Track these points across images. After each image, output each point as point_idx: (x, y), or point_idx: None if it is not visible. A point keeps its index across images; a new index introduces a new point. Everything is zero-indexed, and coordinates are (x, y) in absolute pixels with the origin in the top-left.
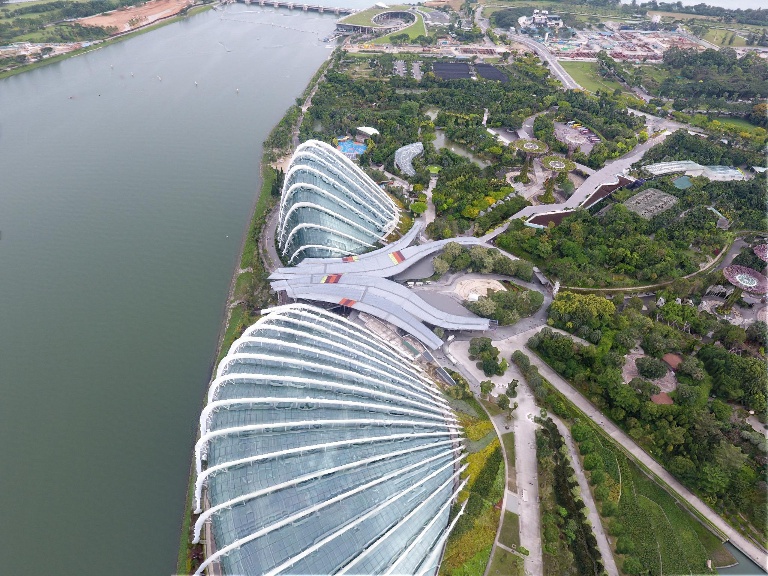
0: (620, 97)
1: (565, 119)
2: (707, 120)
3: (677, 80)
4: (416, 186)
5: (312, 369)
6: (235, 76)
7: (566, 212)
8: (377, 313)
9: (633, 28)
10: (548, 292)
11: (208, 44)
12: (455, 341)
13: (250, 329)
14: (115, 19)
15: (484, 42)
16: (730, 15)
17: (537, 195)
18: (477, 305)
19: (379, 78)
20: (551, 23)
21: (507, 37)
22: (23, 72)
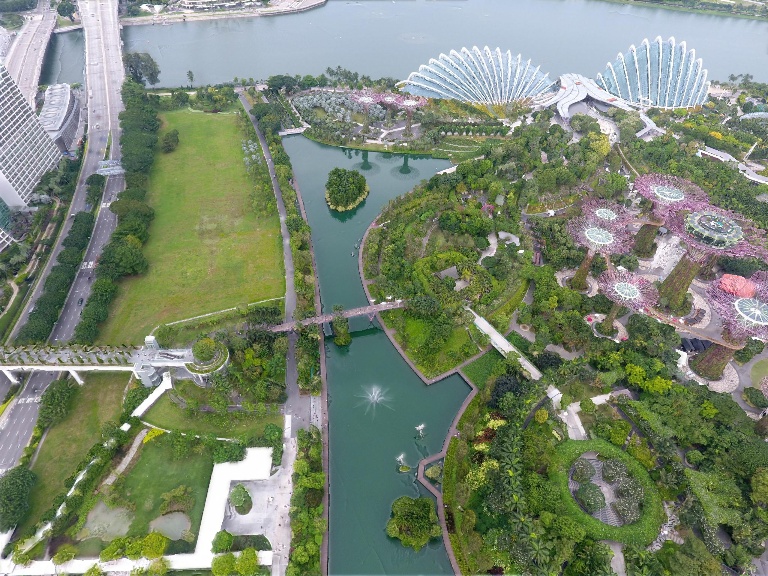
0: None
1: None
2: None
3: None
4: None
5: None
6: None
7: (739, 172)
8: None
9: None
10: None
11: None
12: None
13: None
14: None
15: None
16: None
17: None
18: None
19: None
20: None
21: None
22: (763, 21)
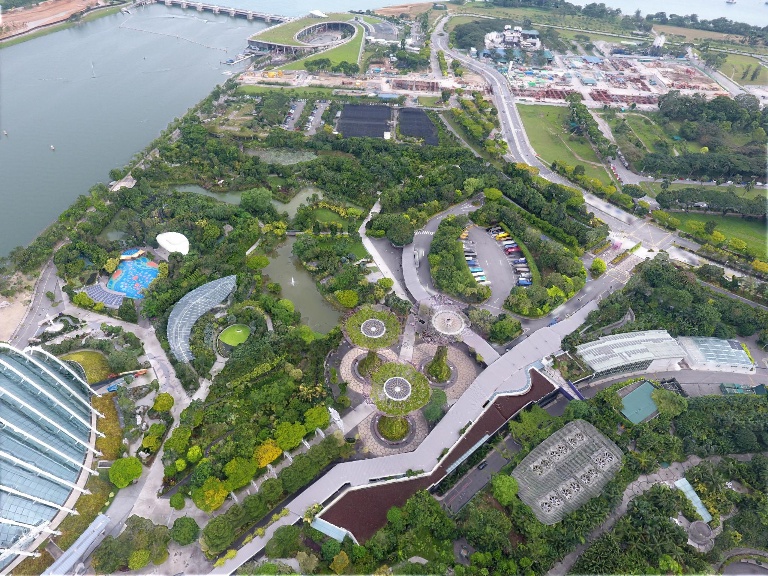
0: (582, 178)
1: (488, 222)
2: (704, 231)
3: (671, 146)
4: (157, 402)
5: None
6: (72, 120)
7: (408, 480)
8: None
9: (629, 52)
10: None
11: (75, 65)
12: None
13: None
14: None
15: (429, 70)
16: (756, 36)
17: None
18: None
19: (255, 132)
20: (526, 42)
21: (462, 63)
22: None
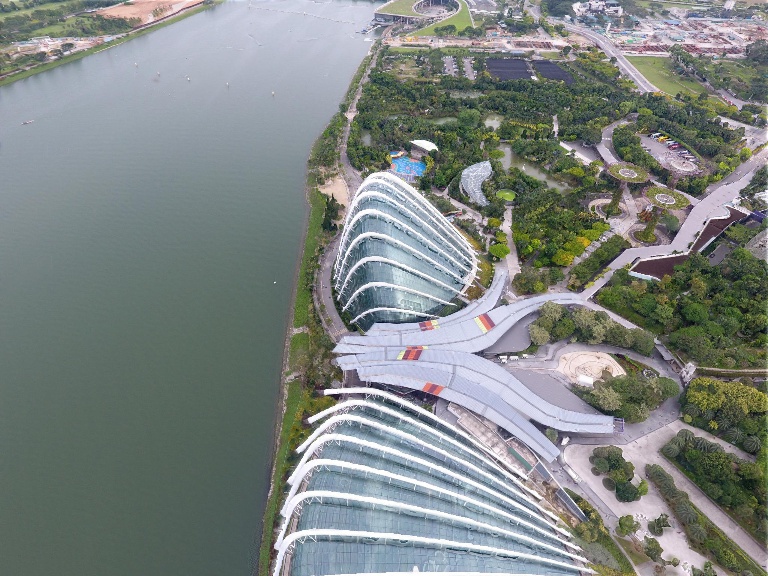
0: (707, 102)
1: (648, 130)
2: None
3: None
4: (492, 221)
5: (411, 511)
6: (269, 75)
7: (675, 257)
8: (471, 405)
9: (702, 15)
10: (673, 371)
11: (237, 37)
12: (570, 445)
13: (323, 439)
14: (138, 9)
15: (538, 33)
16: None
17: (633, 231)
18: (595, 396)
19: (428, 78)
20: (609, 10)
21: None
22: (43, 71)
